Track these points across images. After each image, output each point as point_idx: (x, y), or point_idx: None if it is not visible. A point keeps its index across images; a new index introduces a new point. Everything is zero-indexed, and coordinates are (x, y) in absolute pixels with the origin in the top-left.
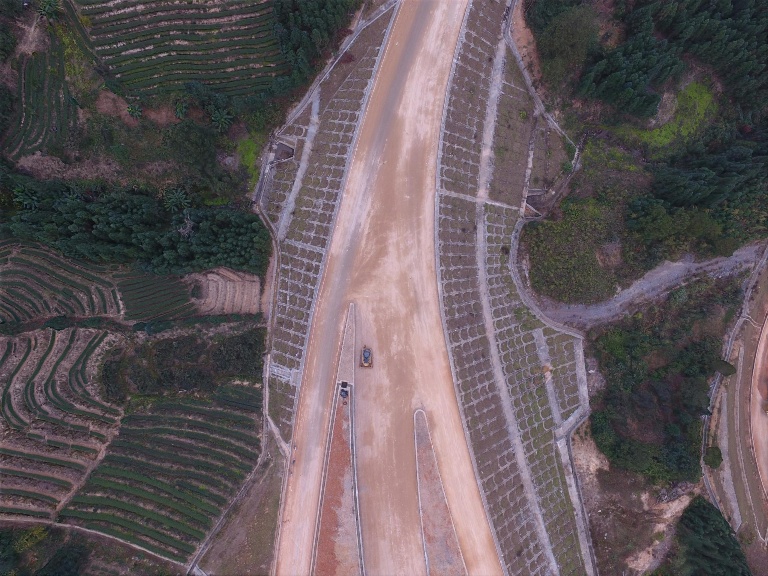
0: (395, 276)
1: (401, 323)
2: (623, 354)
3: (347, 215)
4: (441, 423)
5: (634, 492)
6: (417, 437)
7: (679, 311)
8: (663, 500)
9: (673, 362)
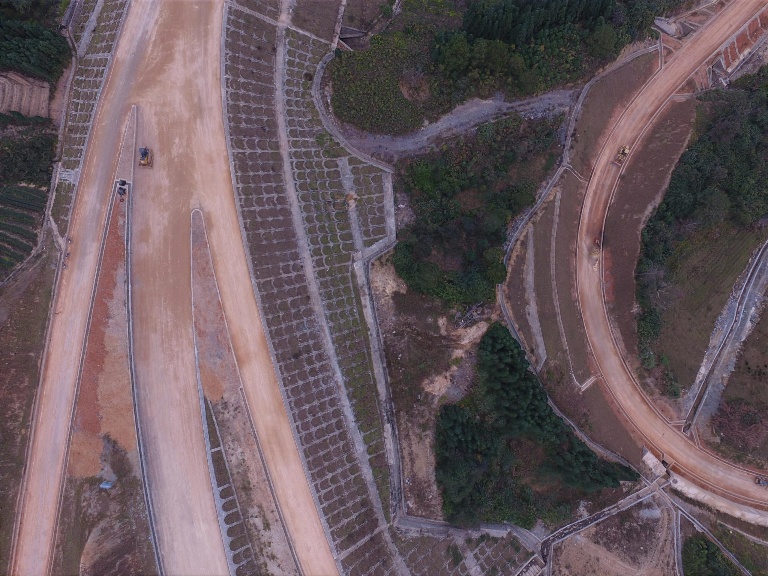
0: (180, 82)
1: (183, 127)
2: (433, 190)
3: (135, 22)
4: (219, 223)
5: (430, 315)
6: (193, 235)
7: (490, 149)
8: (460, 325)
9: (487, 203)
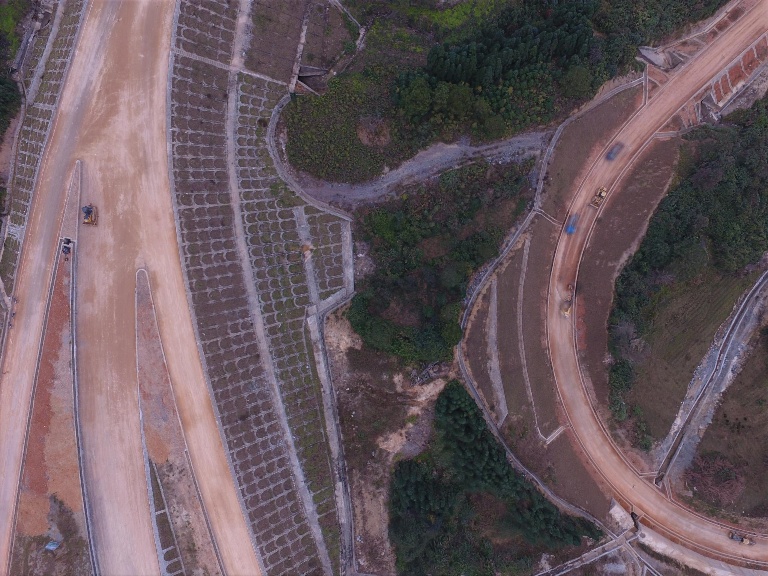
0: (125, 135)
1: (129, 183)
2: (394, 239)
3: (79, 72)
4: (164, 283)
5: (385, 372)
6: (137, 296)
7: (454, 196)
8: (417, 382)
9: (451, 251)
